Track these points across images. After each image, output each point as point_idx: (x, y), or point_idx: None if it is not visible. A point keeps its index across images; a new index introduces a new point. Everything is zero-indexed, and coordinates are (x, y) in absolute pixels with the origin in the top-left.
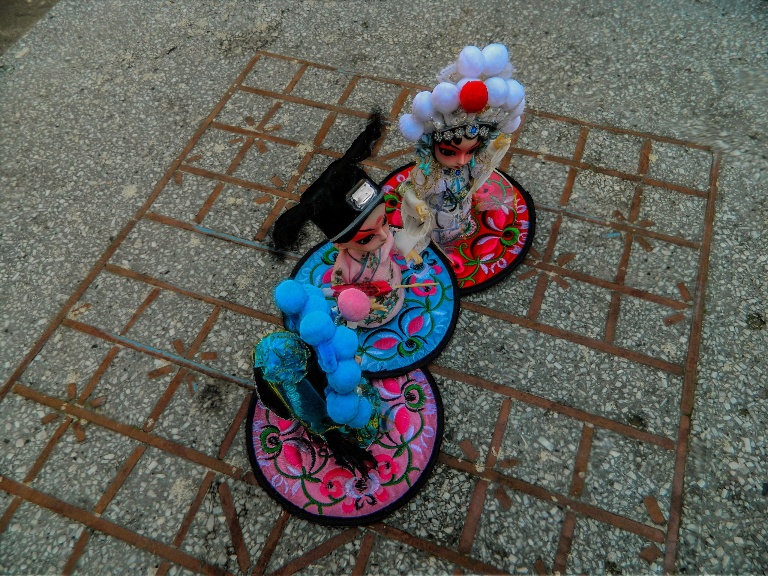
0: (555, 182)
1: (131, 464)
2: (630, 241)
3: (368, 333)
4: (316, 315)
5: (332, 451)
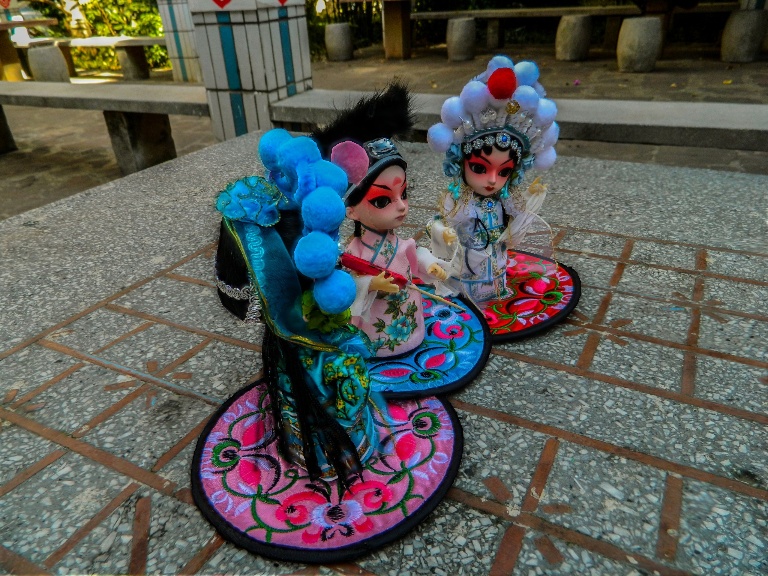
0: (602, 270)
1: (38, 467)
2: (698, 314)
3: (376, 364)
4: None
5: (300, 427)
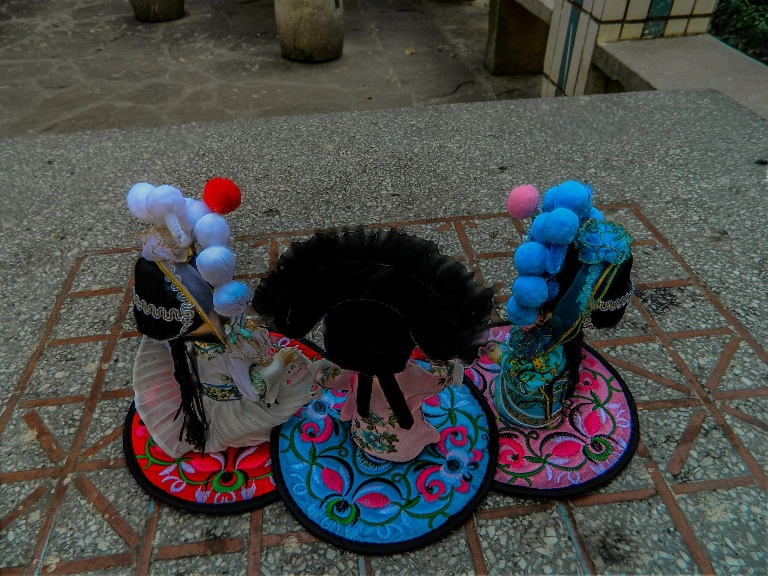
0: None
1: None
2: None
3: (428, 419)
4: (568, 188)
5: None
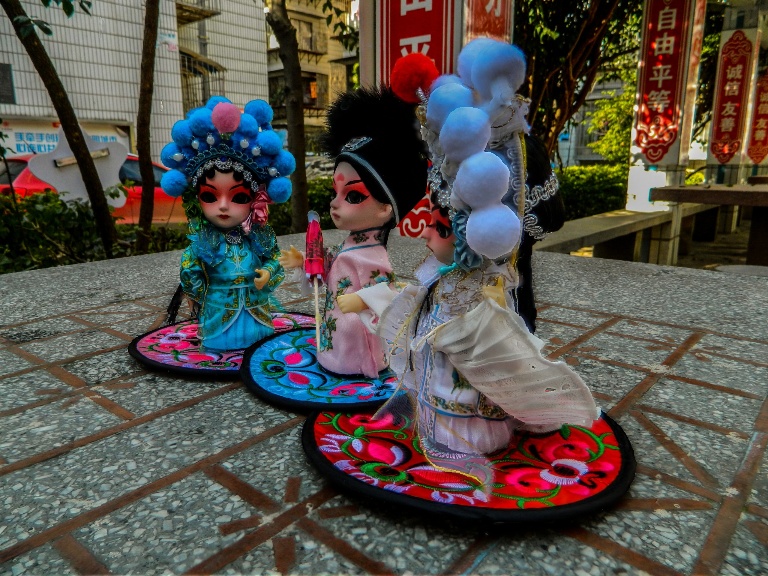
0: None
1: None
2: None
3: None
4: None
5: None
